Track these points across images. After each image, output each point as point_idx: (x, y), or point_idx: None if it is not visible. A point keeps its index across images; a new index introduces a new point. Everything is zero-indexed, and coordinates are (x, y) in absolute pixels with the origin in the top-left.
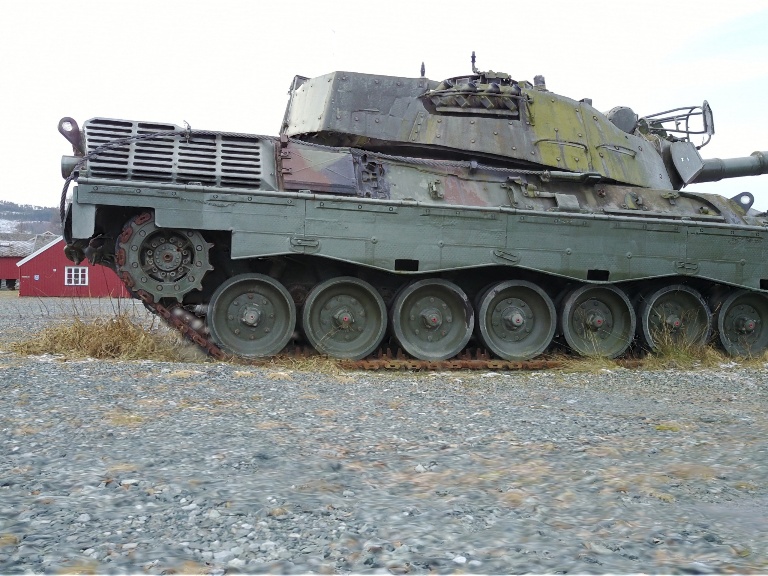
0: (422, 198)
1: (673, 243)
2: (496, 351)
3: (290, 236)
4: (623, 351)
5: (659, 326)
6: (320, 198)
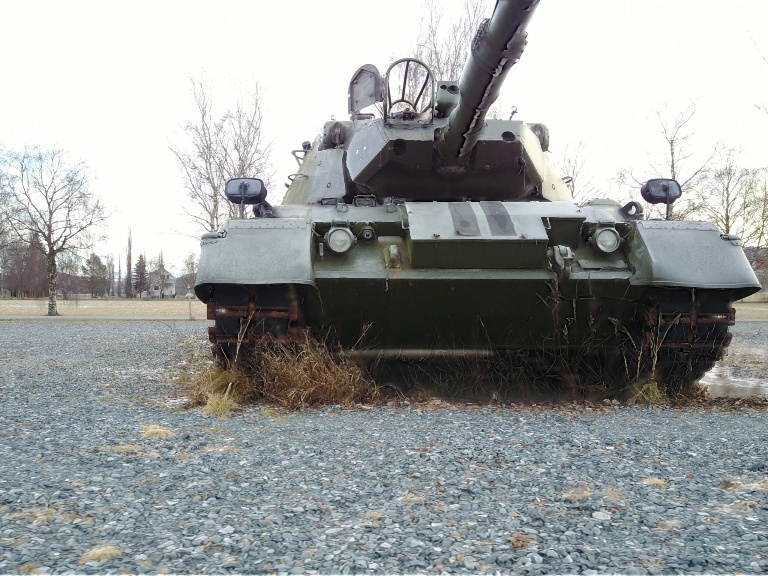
0: None
1: None
2: None
3: None
4: None
5: None
6: None
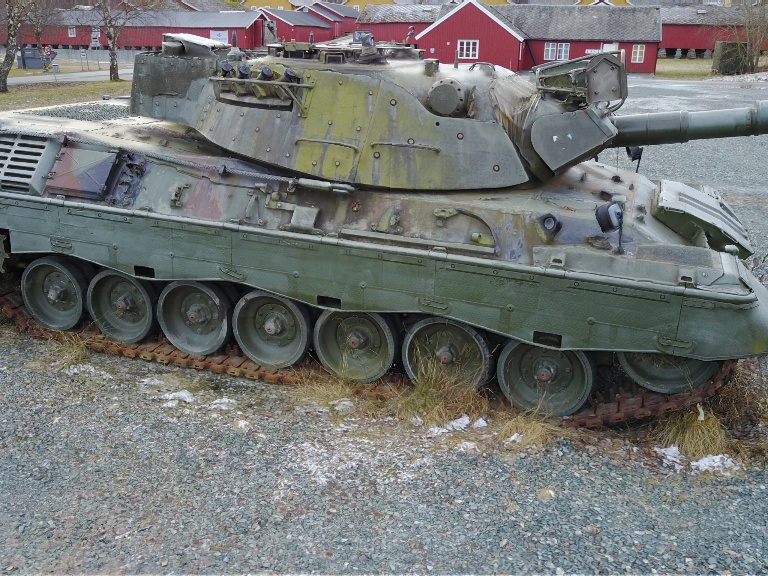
0: (163, 206)
1: (417, 277)
2: (248, 355)
3: (51, 237)
4: (379, 377)
5: (433, 355)
6: (68, 205)
